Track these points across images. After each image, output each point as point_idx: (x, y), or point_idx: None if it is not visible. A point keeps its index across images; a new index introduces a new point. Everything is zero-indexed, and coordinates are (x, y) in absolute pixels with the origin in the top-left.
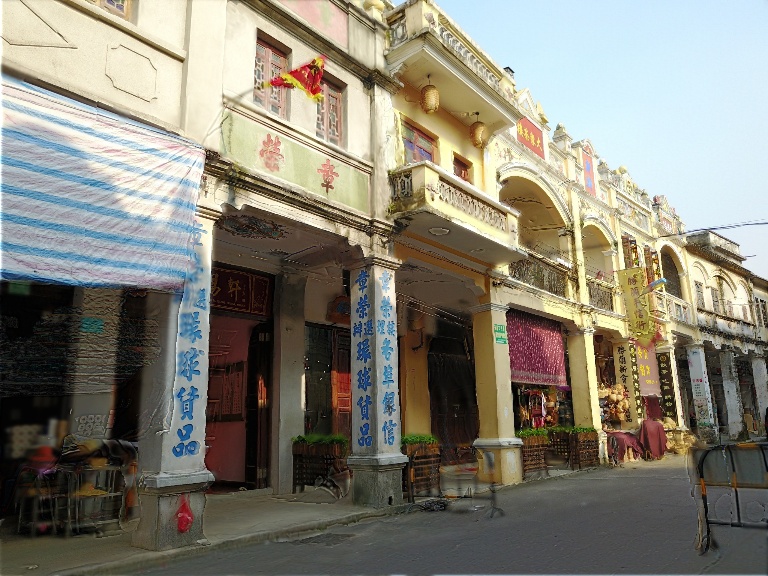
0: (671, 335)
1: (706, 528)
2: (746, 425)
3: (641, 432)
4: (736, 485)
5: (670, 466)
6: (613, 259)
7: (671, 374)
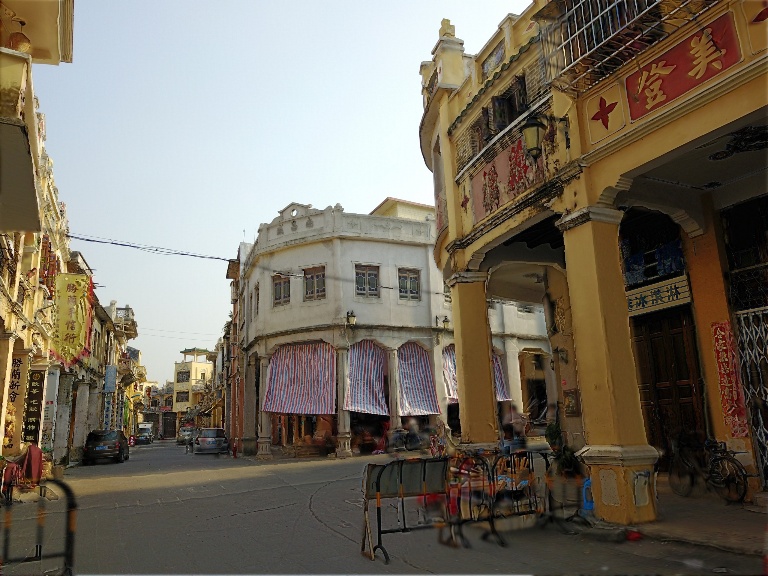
0: (49, 352)
1: (377, 539)
2: (69, 450)
3: (25, 459)
4: (403, 495)
5: (70, 495)
6: (32, 257)
7: (42, 394)
